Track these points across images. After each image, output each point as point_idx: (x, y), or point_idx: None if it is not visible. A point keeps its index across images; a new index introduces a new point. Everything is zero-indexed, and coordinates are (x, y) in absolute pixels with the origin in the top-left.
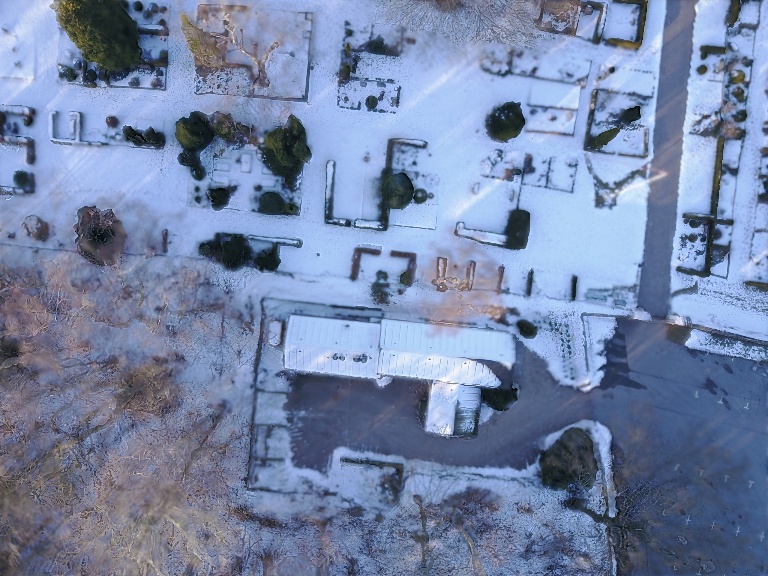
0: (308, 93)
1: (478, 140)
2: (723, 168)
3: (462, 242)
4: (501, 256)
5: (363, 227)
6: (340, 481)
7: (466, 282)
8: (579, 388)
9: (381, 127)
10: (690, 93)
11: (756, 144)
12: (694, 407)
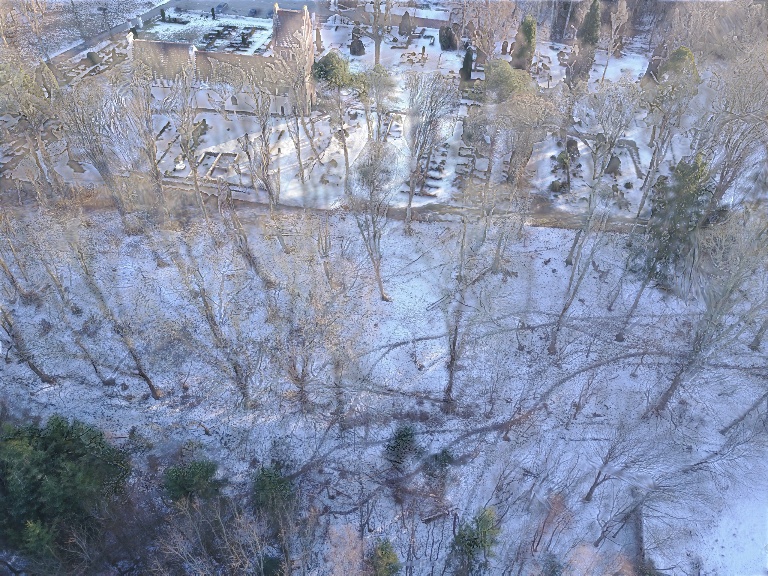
0: None
1: None
2: None
3: None
4: None
5: None
6: (432, 7)
7: None
8: None
9: None
10: None
11: None
12: None
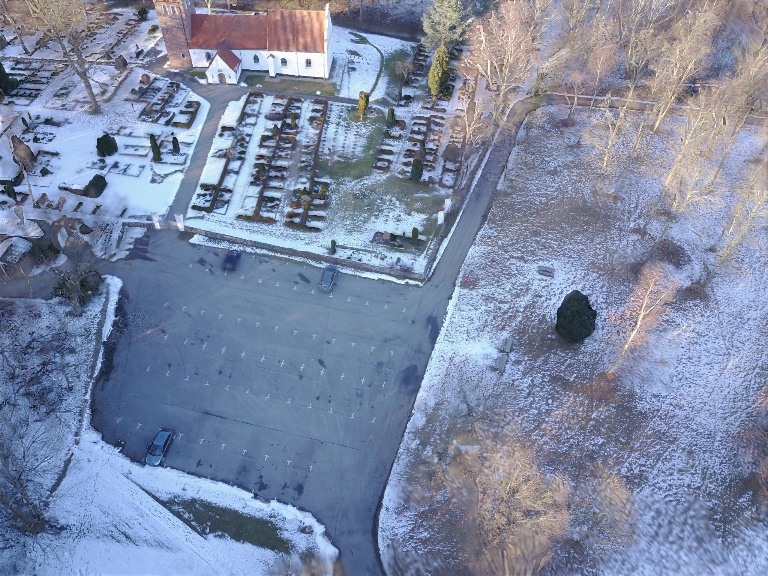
0: (3, 135)
1: (91, 156)
2: (230, 171)
3: (63, 193)
4: (84, 200)
5: (3, 180)
6: None
7: (8, 135)
8: (109, 259)
9: (37, 148)
10: (214, 143)
11: (251, 164)
12: (187, 272)
